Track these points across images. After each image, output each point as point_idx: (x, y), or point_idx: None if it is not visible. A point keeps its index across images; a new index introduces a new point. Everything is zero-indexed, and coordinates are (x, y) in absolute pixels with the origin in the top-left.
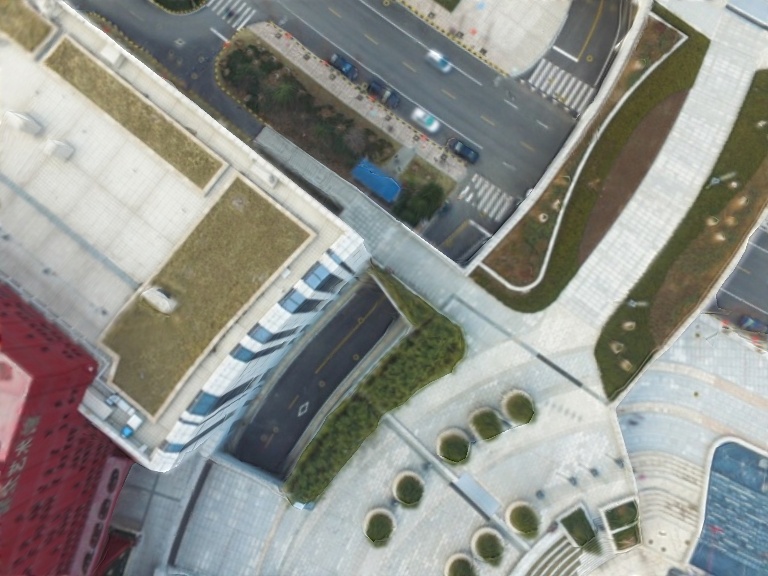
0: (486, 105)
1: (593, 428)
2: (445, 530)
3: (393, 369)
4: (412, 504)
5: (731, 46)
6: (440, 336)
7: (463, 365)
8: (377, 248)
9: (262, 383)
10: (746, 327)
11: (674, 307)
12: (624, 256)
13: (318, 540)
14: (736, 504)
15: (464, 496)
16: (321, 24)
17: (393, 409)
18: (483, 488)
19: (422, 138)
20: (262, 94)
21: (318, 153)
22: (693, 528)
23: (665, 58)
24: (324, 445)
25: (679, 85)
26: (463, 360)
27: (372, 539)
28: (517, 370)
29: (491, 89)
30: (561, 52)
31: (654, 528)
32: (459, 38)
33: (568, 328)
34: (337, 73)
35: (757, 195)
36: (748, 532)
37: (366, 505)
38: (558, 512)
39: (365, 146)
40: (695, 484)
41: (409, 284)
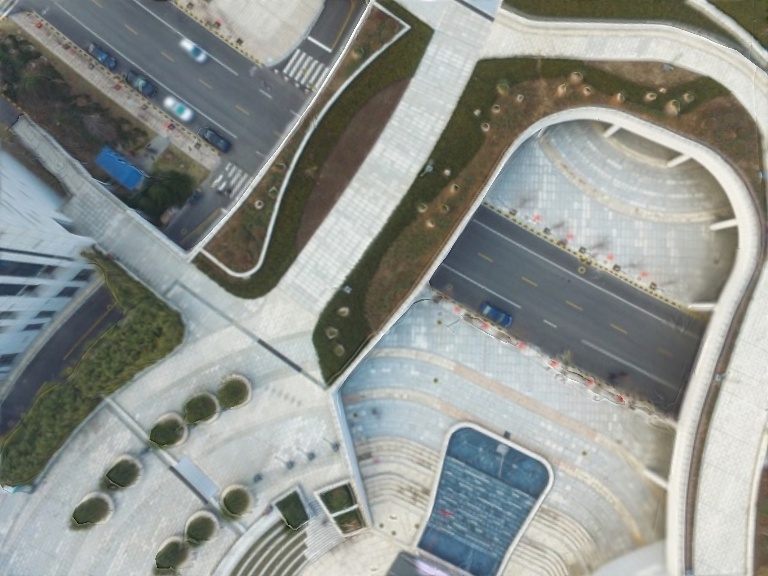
0: (241, 95)
1: (312, 413)
2: (164, 513)
3: (99, 353)
4: (129, 487)
5: (455, 36)
6: (144, 321)
7: (184, 350)
8: (104, 235)
9: (7, 369)
10: (486, 314)
11: (387, 293)
12: (341, 243)
13: (38, 523)
14: (469, 488)
15: (183, 480)
16: (83, 14)
17: (113, 394)
18: (202, 472)
19: (178, 127)
20: (18, 83)
21: (70, 142)
22: (423, 512)
23: (386, 48)
24: (28, 428)
25: (399, 74)
26: (184, 345)
27: (78, 521)
28: (238, 355)
29: (247, 79)
30: (315, 43)
31: (385, 512)
32: (216, 28)
33: (288, 314)
34: (95, 63)
35: (471, 183)
36: (478, 516)
37: (85, 489)
38: (275, 495)
39: (117, 135)
40: (429, 469)
41: (133, 270)
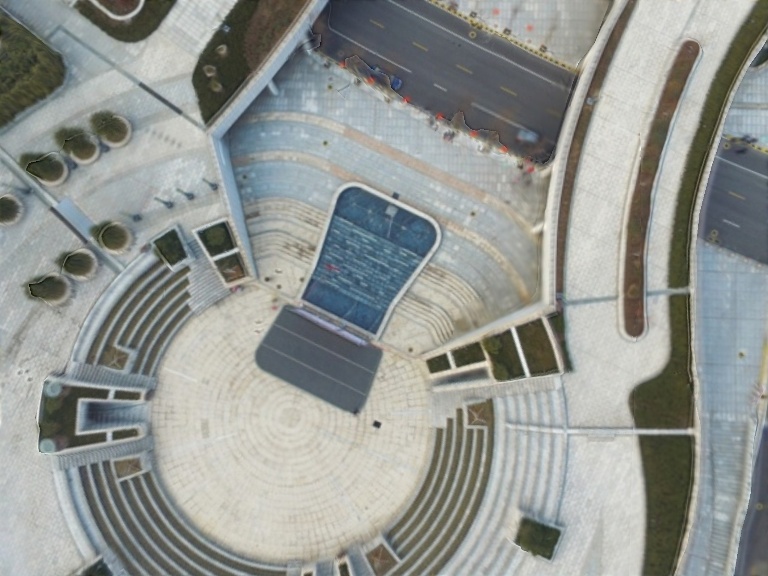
0: None
1: (192, 154)
2: (44, 253)
3: None
4: (9, 225)
5: None
6: (19, 47)
7: (66, 93)
8: None
9: None
10: None
11: (265, 31)
12: None
13: None
14: (356, 246)
15: (64, 220)
16: None
17: None
18: (83, 213)
19: None
20: None
21: None
22: (308, 265)
23: None
24: None
25: None
26: (65, 88)
27: None
28: (119, 98)
29: None
30: None
31: (271, 266)
32: None
33: (169, 57)
34: None
35: None
36: (364, 271)
37: None
38: (154, 235)
39: None
40: (316, 226)
41: (17, 16)
